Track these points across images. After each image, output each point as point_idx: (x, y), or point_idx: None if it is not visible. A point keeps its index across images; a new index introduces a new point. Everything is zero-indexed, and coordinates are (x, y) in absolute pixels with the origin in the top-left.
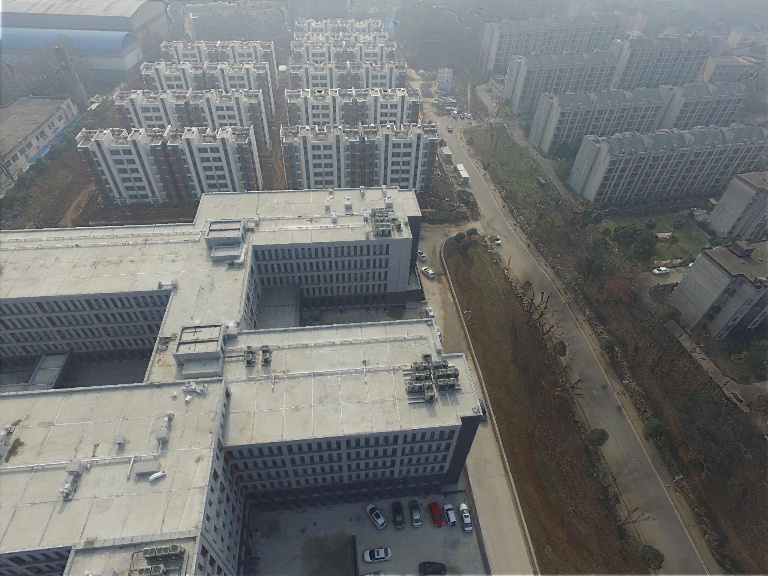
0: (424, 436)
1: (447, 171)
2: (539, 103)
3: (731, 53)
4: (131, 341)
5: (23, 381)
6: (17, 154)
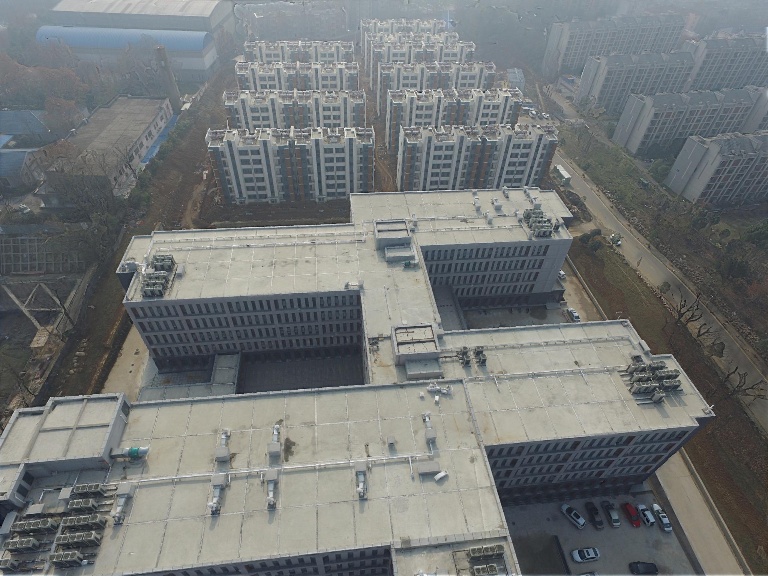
0: (654, 437)
1: None
2: (627, 104)
3: None
4: (300, 341)
5: (193, 380)
6: (133, 154)
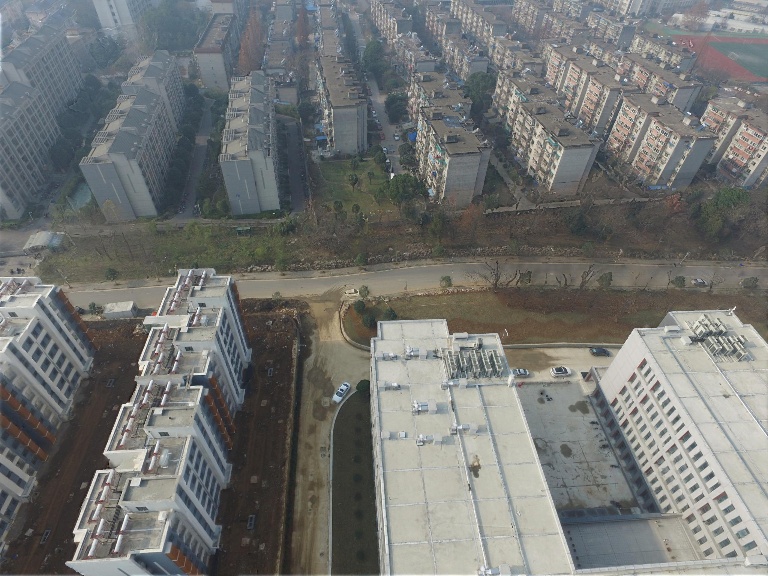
0: None
1: None
2: (87, 176)
3: None
4: None
5: None
6: None
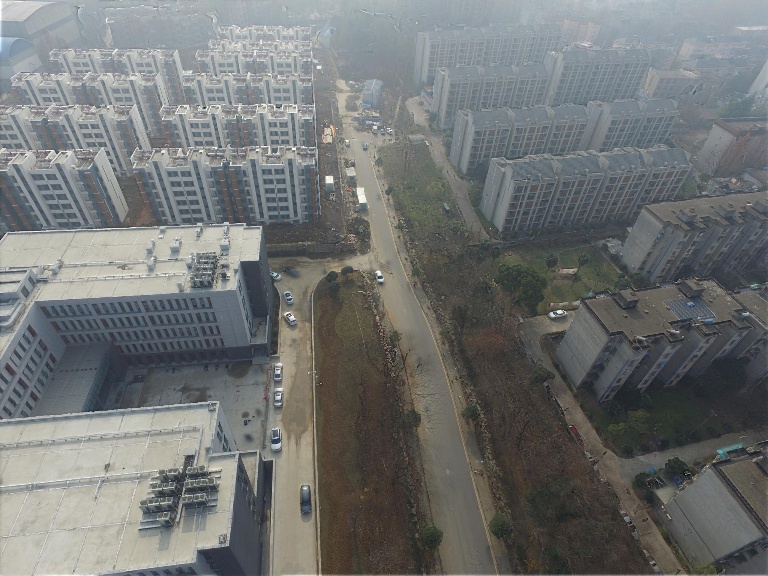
0: (156, 572)
1: (347, 195)
2: (456, 120)
3: (680, 65)
4: None
5: None
6: None
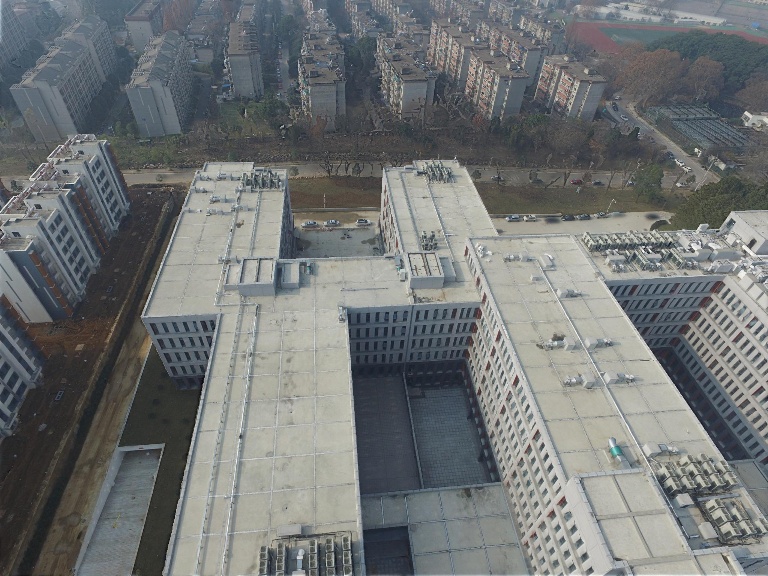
0: None
1: None
2: (16, 99)
3: None
4: None
5: None
6: None
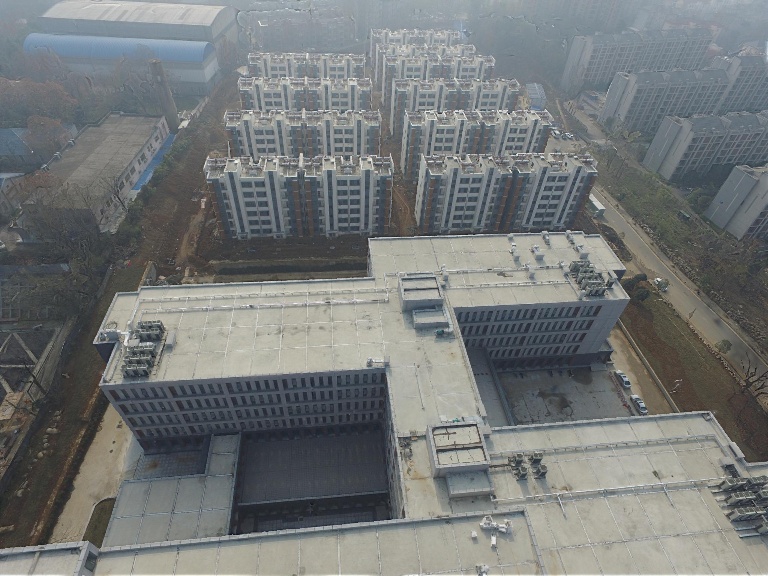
0: None
1: None
2: (661, 126)
3: None
4: (312, 419)
5: (185, 464)
6: (123, 181)
